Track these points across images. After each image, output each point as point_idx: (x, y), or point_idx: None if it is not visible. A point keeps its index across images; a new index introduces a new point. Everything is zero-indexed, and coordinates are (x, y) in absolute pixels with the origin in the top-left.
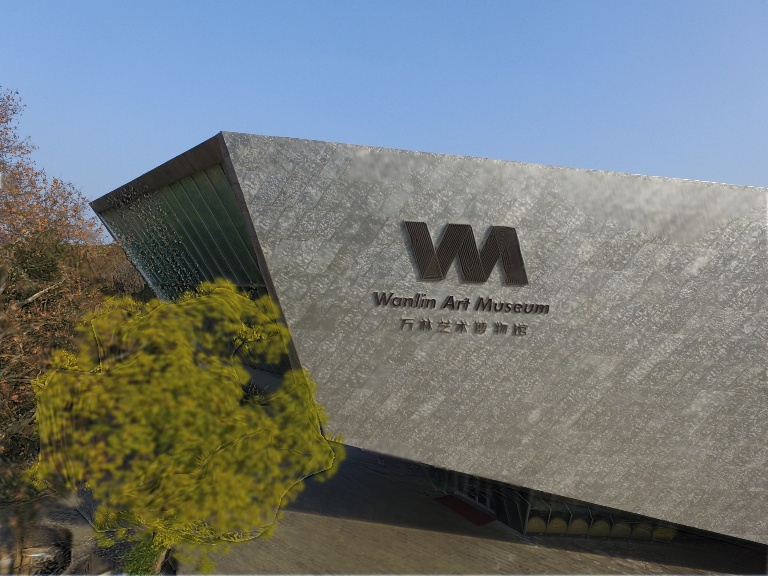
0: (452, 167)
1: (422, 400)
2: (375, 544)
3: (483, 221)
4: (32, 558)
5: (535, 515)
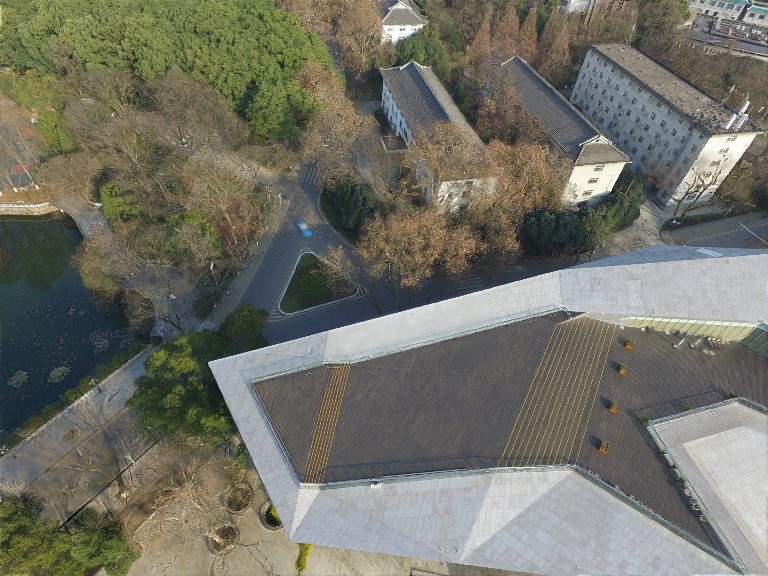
0: None
1: None
2: None
3: None
4: (240, 489)
5: None
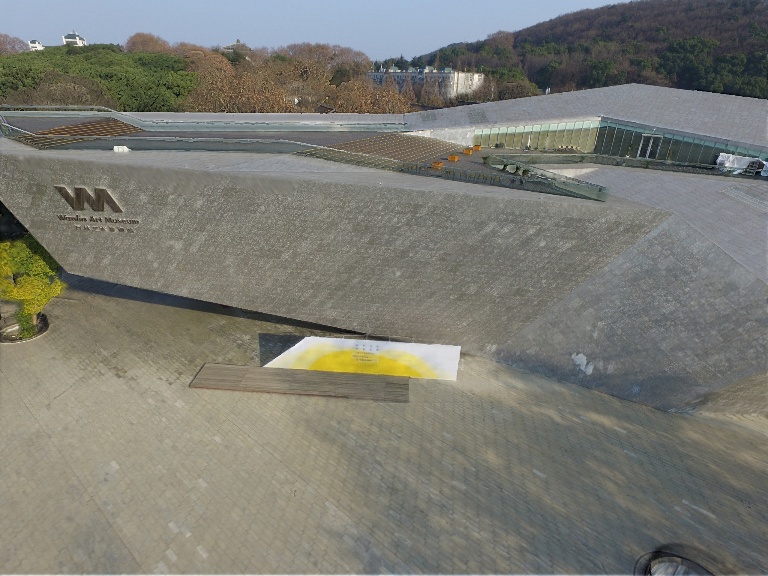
0: (65, 163)
1: (102, 258)
2: (158, 315)
3: (91, 186)
4: None
5: None
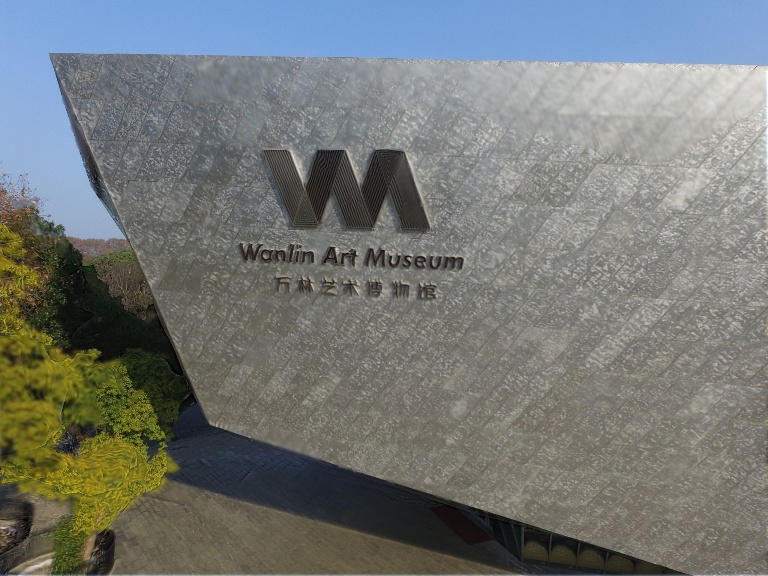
0: (315, 74)
1: (313, 381)
2: (338, 553)
3: (363, 145)
4: None
5: (532, 539)
